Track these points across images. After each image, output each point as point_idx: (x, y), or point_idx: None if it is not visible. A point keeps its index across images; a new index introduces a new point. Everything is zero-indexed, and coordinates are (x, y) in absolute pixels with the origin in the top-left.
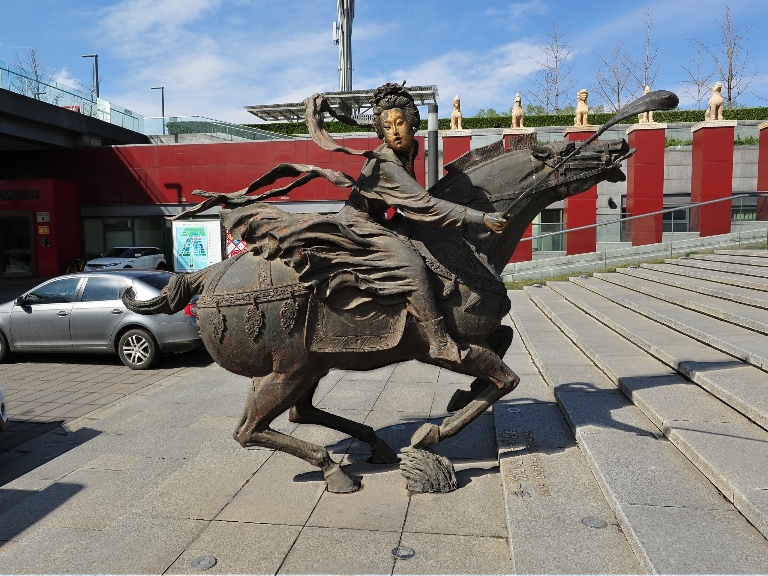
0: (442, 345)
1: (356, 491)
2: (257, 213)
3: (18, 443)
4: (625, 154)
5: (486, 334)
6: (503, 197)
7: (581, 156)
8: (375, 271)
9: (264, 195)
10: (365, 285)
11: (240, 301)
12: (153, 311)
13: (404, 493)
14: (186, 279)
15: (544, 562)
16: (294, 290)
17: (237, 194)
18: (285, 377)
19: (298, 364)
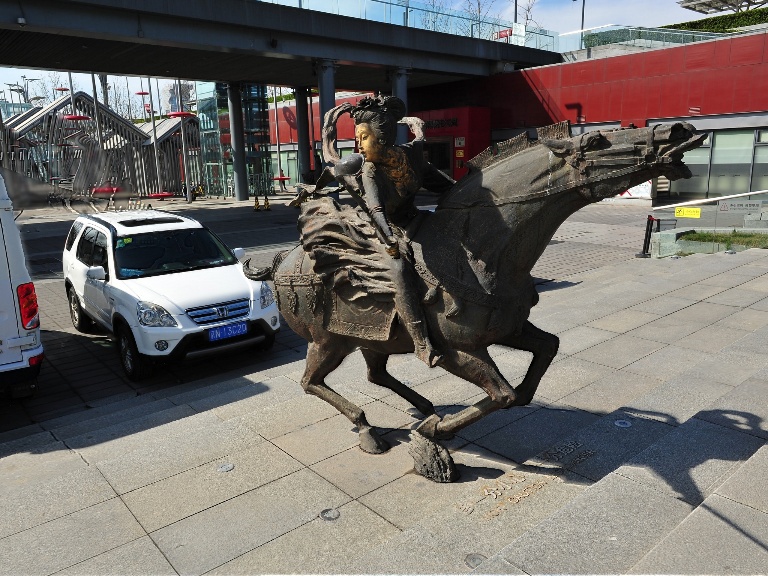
0: (420, 347)
1: (377, 454)
2: (319, 207)
3: (301, 344)
4: (679, 144)
5: (473, 344)
6: (510, 200)
7: (610, 150)
8: (373, 270)
9: (340, 188)
10: (358, 282)
11: (284, 282)
12: (258, 279)
13: (406, 469)
14: (281, 256)
15: (376, 569)
16: (313, 279)
17: (311, 189)
18: (319, 347)
19: (325, 339)
